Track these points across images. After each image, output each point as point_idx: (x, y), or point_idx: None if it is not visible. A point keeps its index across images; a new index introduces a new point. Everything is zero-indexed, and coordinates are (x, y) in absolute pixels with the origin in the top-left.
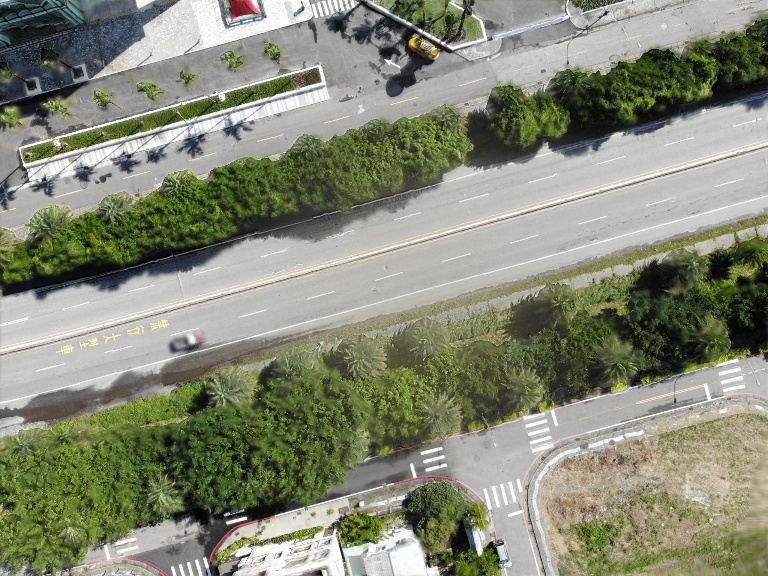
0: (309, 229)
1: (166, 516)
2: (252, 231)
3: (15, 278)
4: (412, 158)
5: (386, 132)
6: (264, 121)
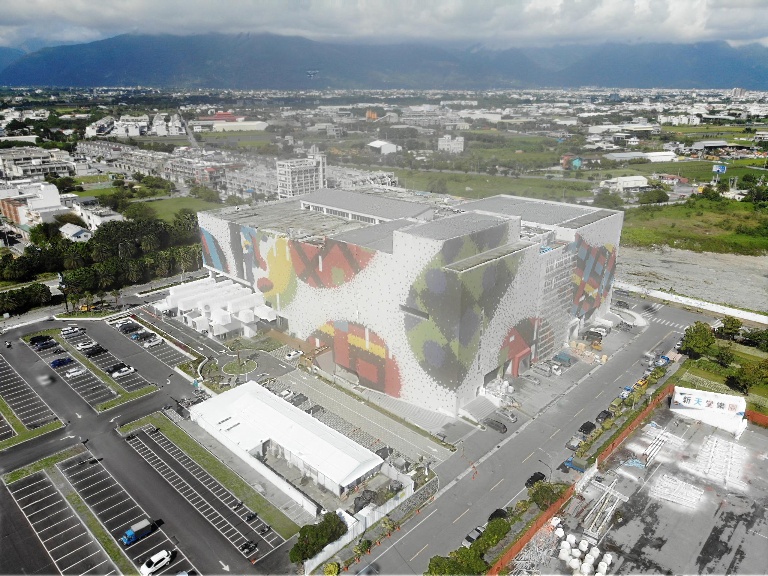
0: None
1: None
2: None
3: None
4: None
5: None
6: None
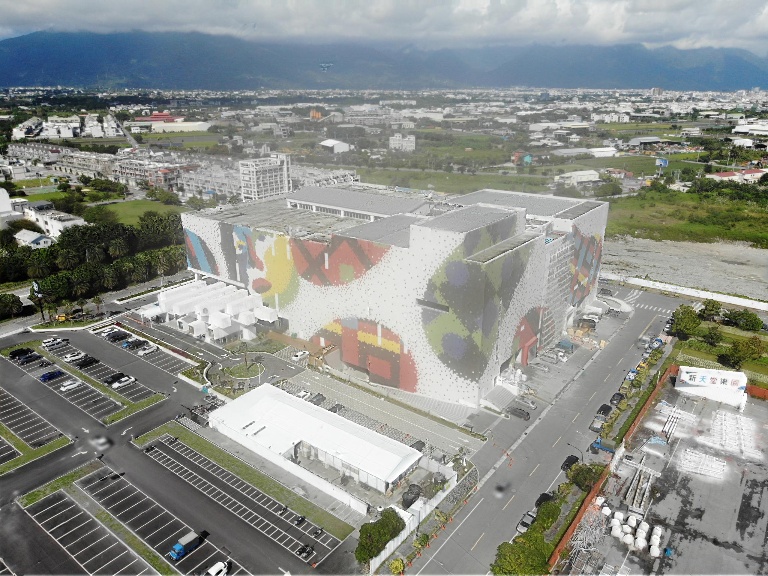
0: None
1: None
2: None
3: None
4: None
5: (72, 279)
6: None
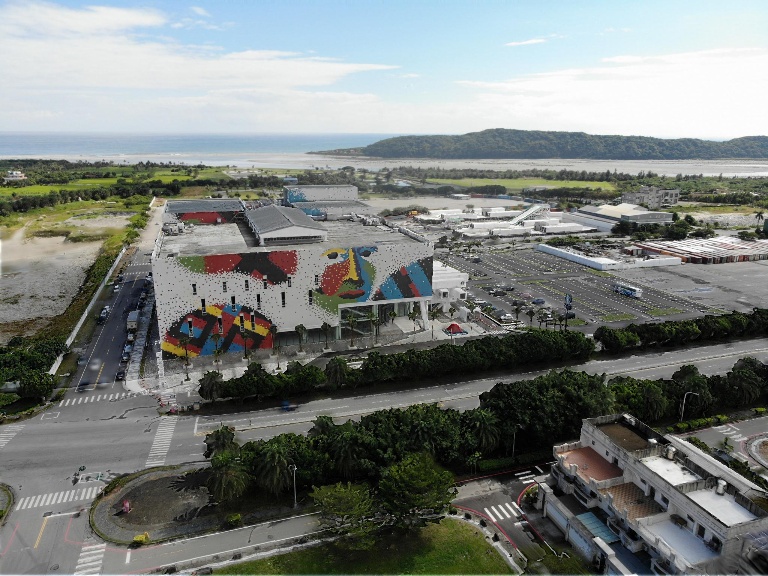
0: None
1: (479, 453)
2: (486, 378)
3: (352, 378)
4: None
5: None
6: None
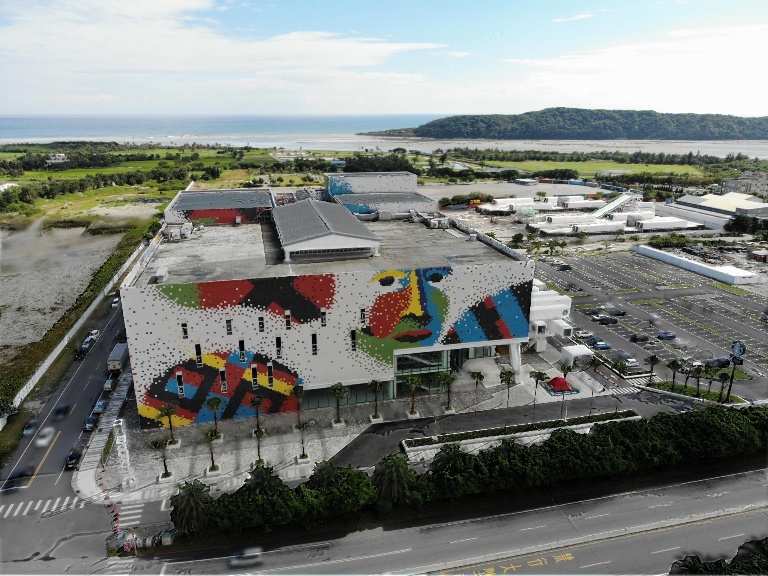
0: (684, 490)
1: None
2: (629, 491)
3: (416, 496)
4: (759, 419)
5: None
6: None
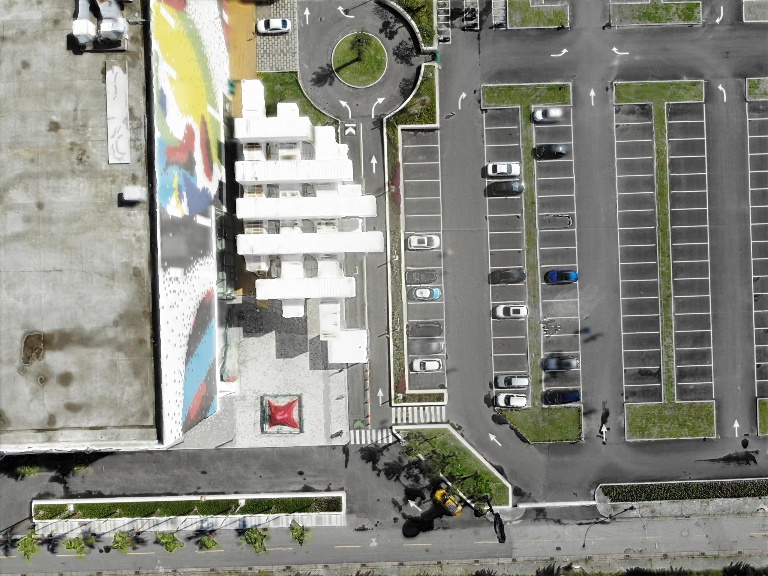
0: None
1: None
2: None
3: None
4: None
5: None
6: (277, 531)
